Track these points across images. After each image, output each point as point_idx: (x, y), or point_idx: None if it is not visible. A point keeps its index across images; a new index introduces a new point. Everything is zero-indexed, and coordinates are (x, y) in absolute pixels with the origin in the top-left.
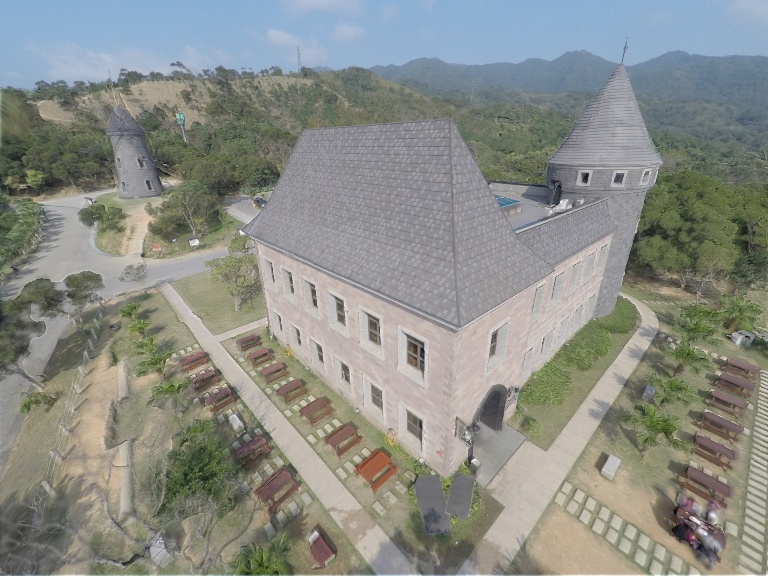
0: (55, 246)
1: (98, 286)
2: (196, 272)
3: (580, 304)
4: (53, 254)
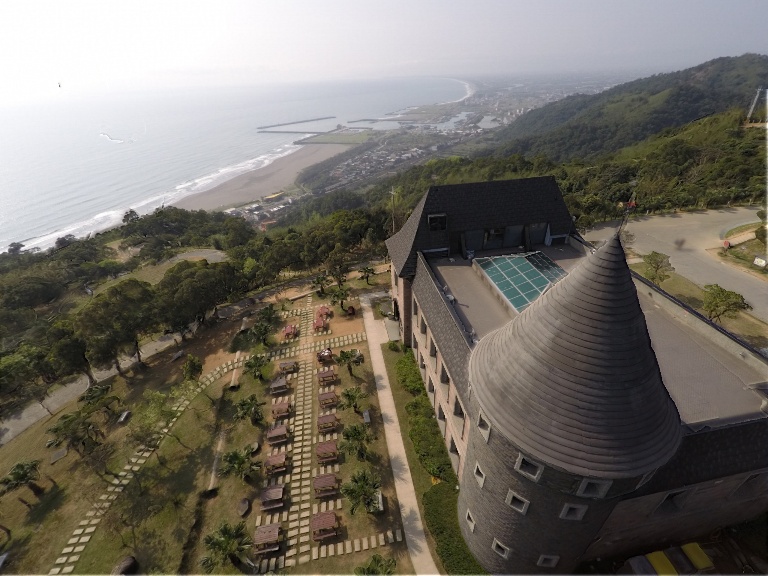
0: (735, 212)
1: (590, 227)
2: (678, 271)
3: (443, 409)
4: (712, 215)
